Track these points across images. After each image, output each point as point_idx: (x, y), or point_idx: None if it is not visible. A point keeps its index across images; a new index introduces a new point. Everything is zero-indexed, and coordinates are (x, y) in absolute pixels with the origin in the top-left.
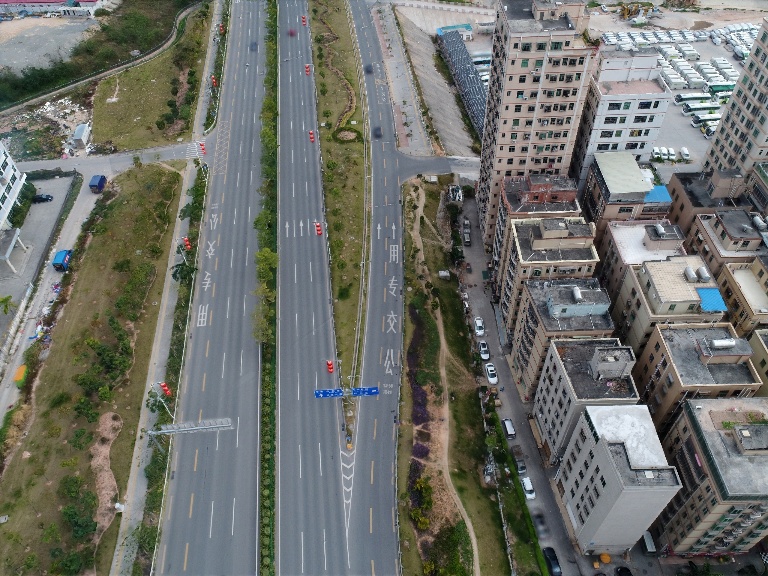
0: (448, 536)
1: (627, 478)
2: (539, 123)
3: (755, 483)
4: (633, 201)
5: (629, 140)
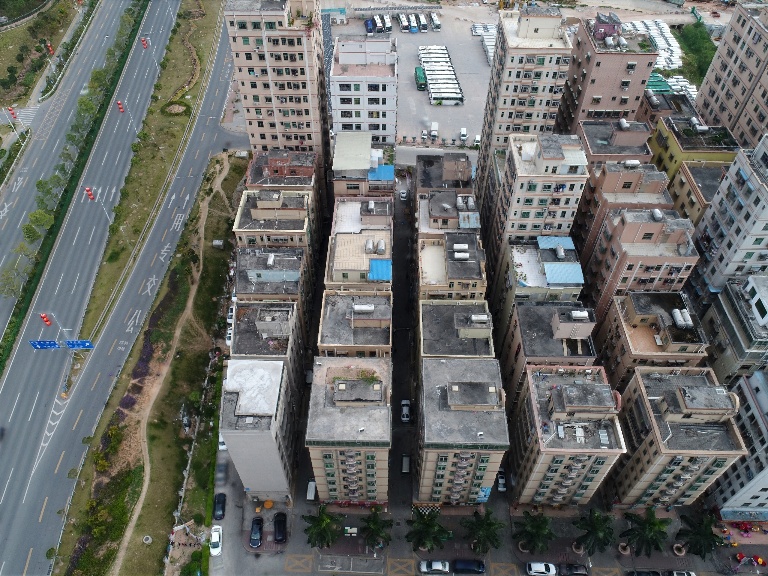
0: (123, 478)
1: (227, 422)
2: (278, 100)
3: (335, 430)
4: (357, 178)
5: (370, 121)
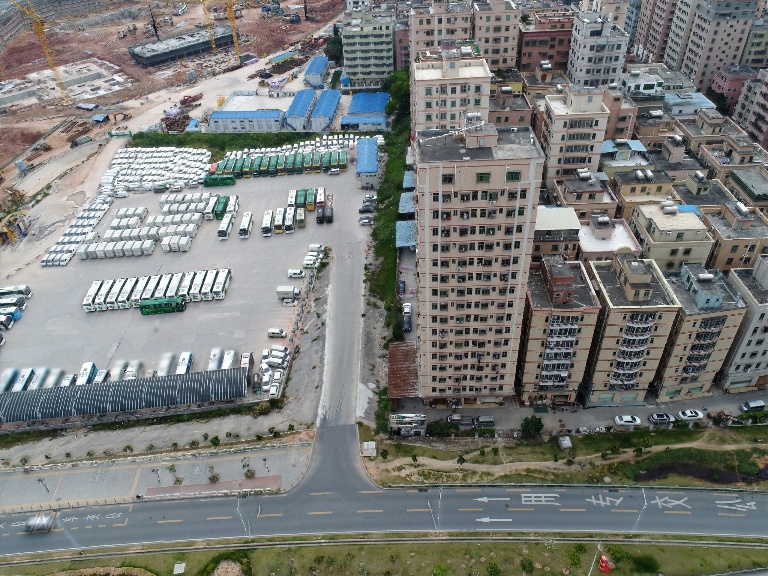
0: None
1: None
2: None
3: None
4: None
5: None
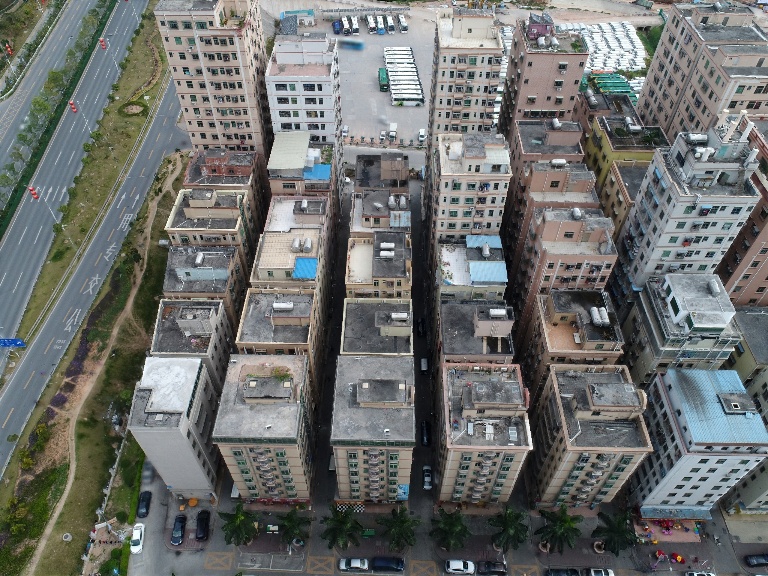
0: (47, 476)
1: (137, 419)
2: (216, 100)
3: (242, 427)
4: (293, 177)
5: (308, 121)
